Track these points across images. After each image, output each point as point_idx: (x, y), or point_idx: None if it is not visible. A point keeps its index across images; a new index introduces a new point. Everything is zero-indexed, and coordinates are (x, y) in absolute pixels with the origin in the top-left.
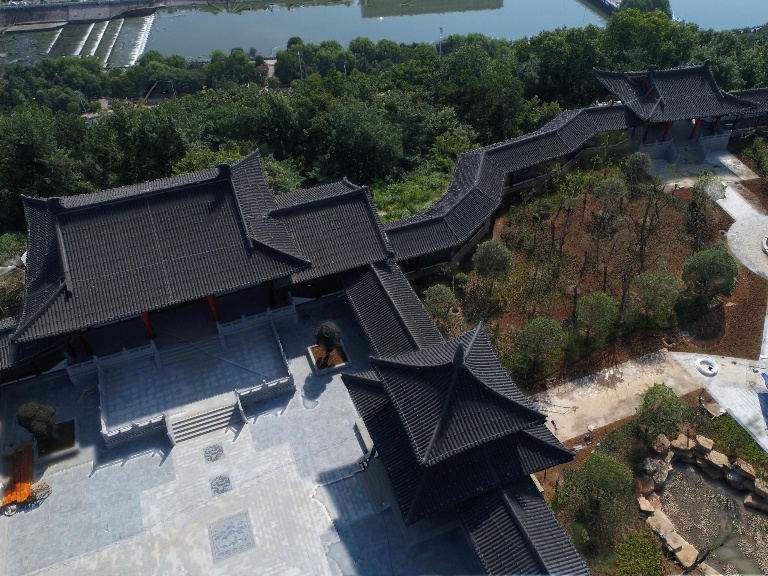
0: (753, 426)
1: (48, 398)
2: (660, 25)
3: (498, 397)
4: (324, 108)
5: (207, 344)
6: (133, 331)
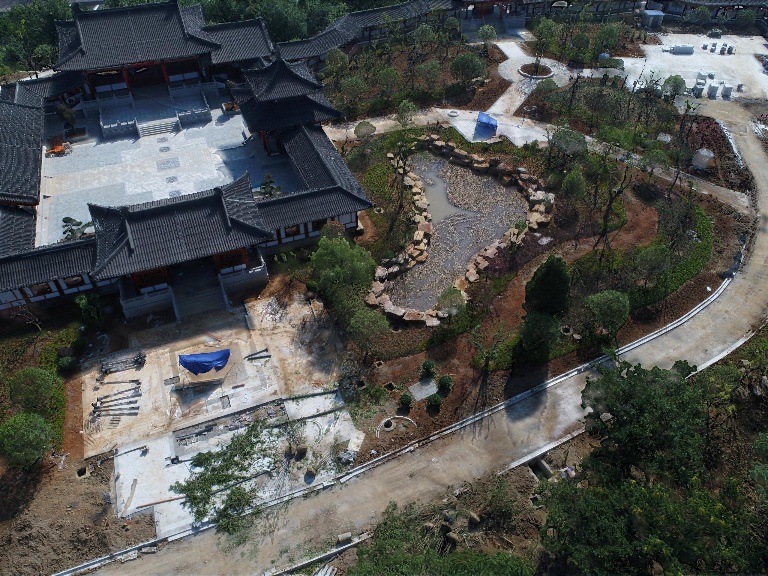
0: (466, 133)
1: None
2: None
3: (301, 79)
4: (255, 2)
5: (163, 100)
6: (120, 94)
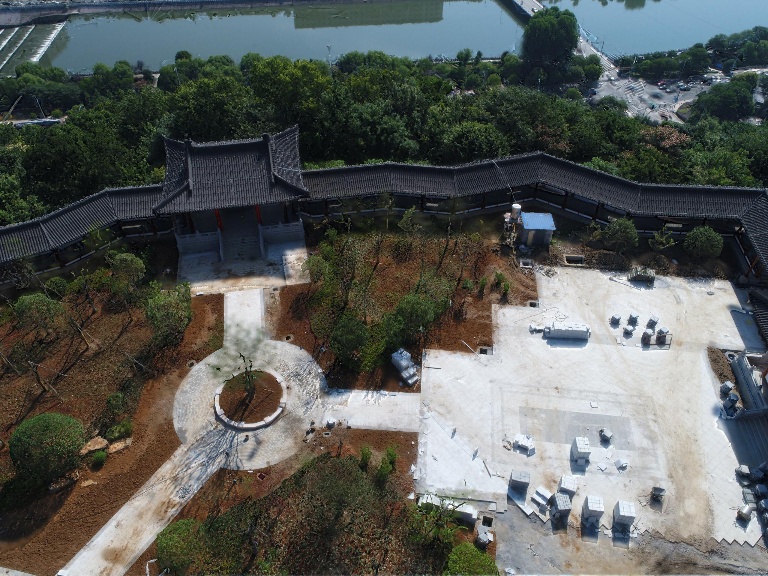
0: None
1: None
2: (299, 79)
3: None
4: None
5: None
6: None
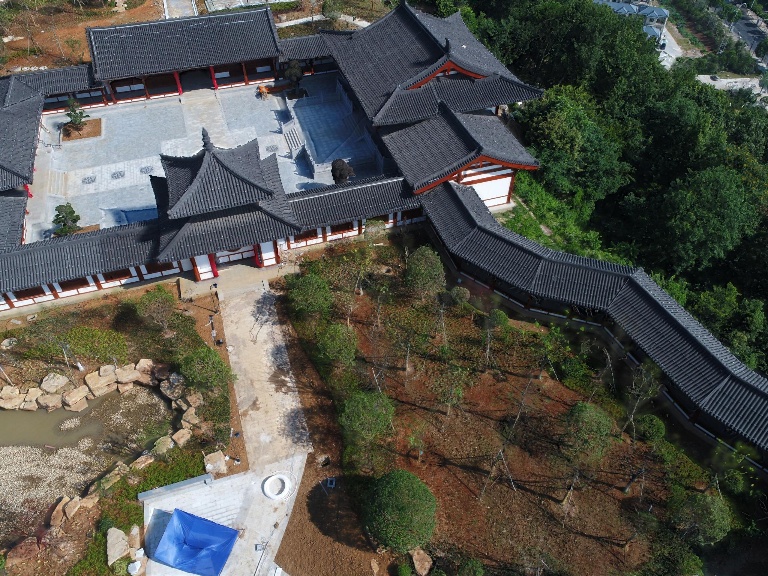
0: (186, 501)
1: (330, 89)
2: None
3: None
4: None
5: (358, 132)
6: None
